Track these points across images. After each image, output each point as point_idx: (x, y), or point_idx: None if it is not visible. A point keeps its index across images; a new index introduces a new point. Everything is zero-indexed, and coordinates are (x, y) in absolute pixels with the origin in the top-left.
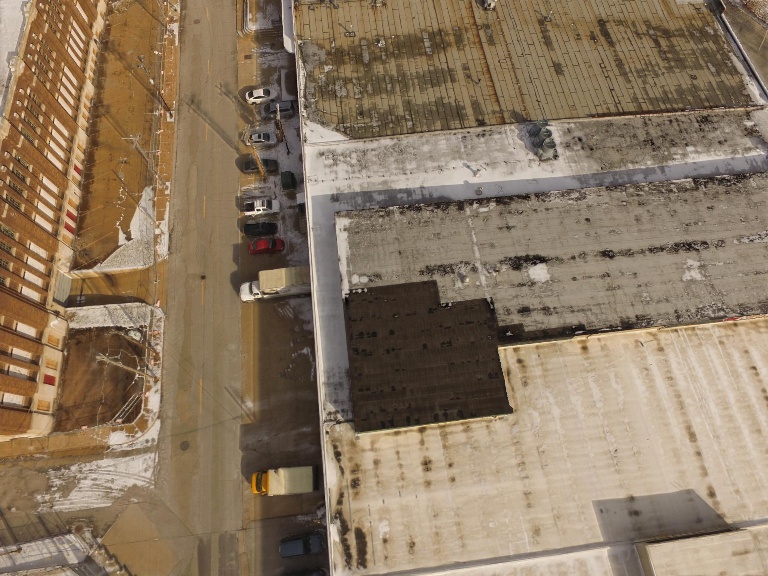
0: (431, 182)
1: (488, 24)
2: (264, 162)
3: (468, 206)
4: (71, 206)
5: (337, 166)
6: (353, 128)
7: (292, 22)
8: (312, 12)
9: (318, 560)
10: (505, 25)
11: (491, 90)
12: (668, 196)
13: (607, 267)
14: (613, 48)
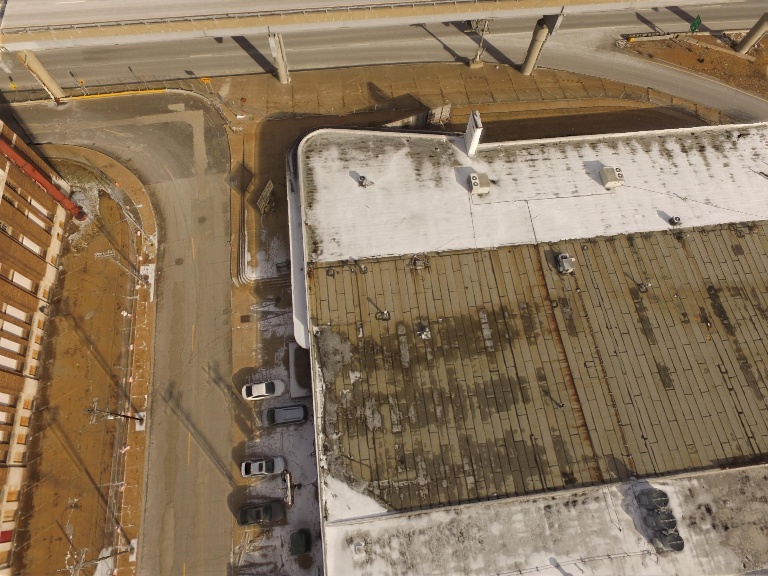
0: None
1: (565, 298)
2: (267, 511)
3: None
4: None
5: (372, 564)
6: (392, 489)
7: None
8: (331, 280)
9: None
10: (588, 300)
11: (578, 417)
12: None
13: None
14: (733, 337)
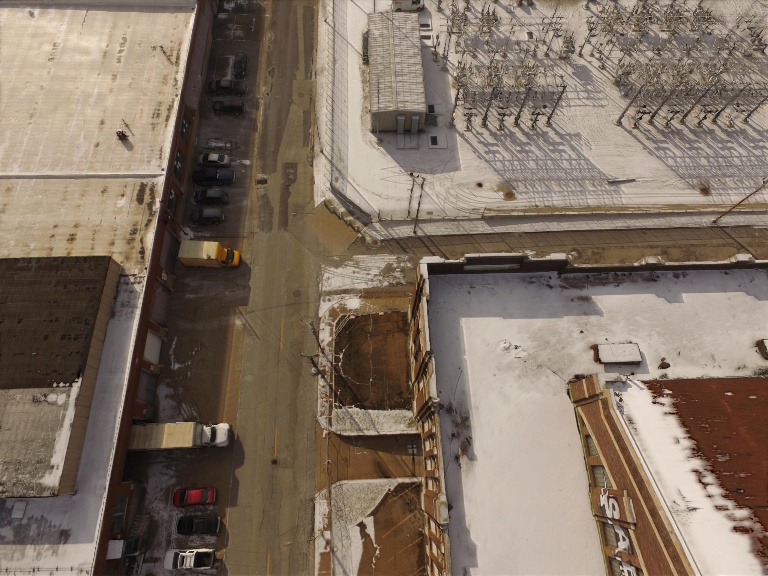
0: None
1: None
2: None
3: None
4: None
5: None
6: None
7: None
8: None
9: (199, 209)
10: None
11: None
12: None
13: None
14: None
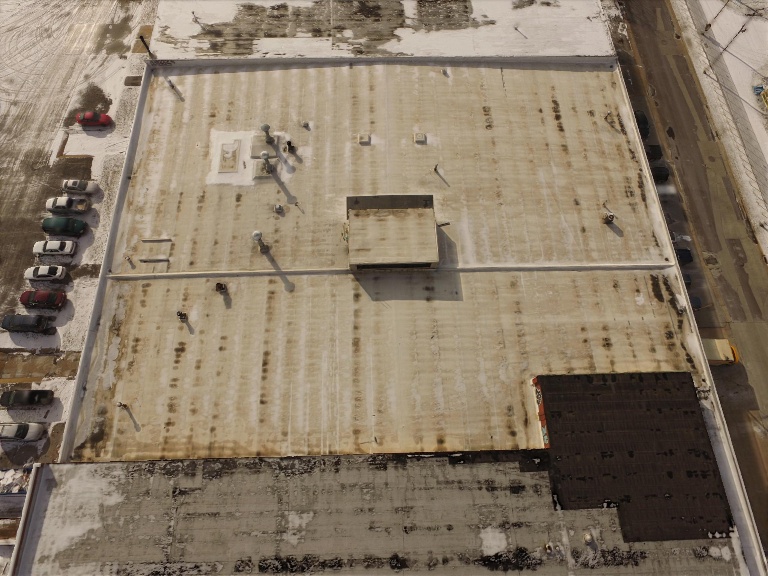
0: None
1: None
2: None
3: None
4: None
5: None
6: None
7: None
8: None
9: None
10: None
11: None
12: None
13: (405, 542)
14: None
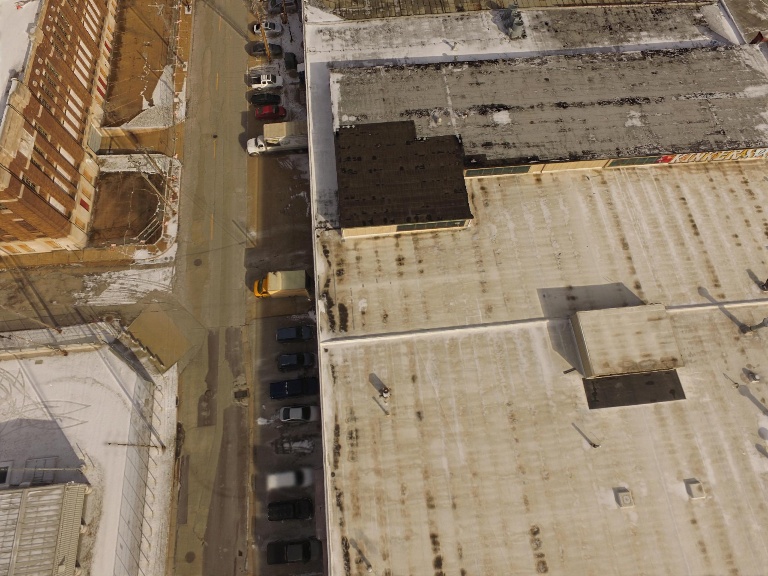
0: (414, 54)
1: None
2: (270, 46)
3: (444, 67)
4: (102, 75)
5: (333, 41)
6: (348, 12)
7: None
8: None
9: (308, 347)
10: None
11: None
12: (618, 63)
13: (561, 115)
14: None
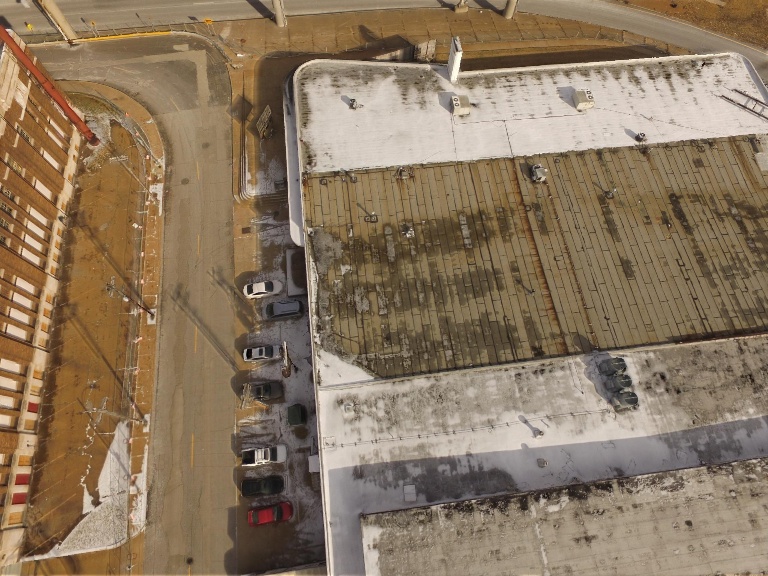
0: (480, 446)
1: (538, 203)
2: (266, 389)
3: (533, 502)
4: (22, 465)
5: (360, 421)
6: (378, 361)
7: (300, 204)
8: (324, 188)
9: None
10: (559, 205)
11: (547, 302)
12: None
13: None
14: (691, 236)
